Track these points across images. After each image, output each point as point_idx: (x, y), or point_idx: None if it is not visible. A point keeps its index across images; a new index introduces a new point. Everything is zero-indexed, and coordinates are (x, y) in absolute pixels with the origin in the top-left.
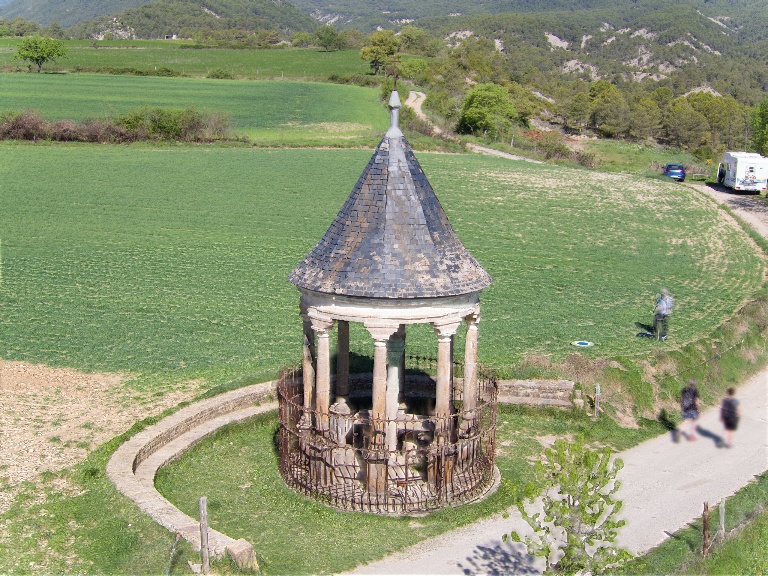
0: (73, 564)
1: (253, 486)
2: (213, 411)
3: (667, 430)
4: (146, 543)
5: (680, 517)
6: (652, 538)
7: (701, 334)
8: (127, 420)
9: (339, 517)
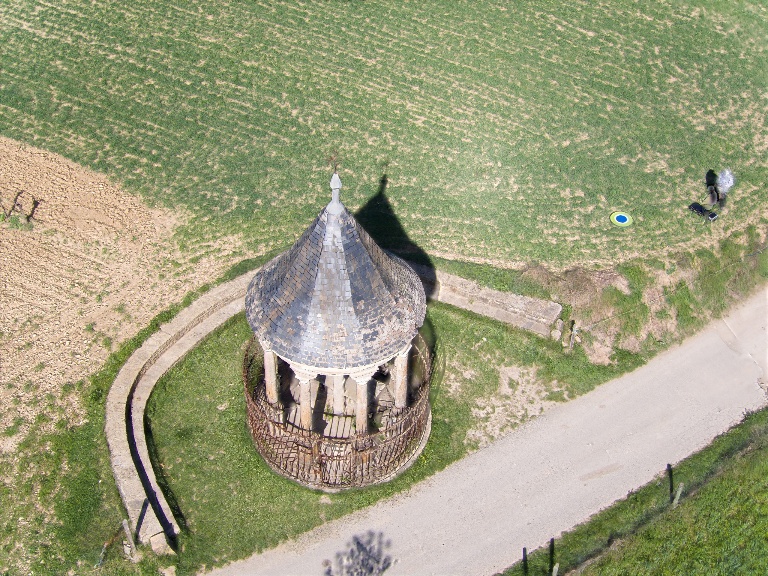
0: (48, 524)
1: (227, 410)
2: (228, 299)
3: (638, 366)
4: (105, 507)
5: (552, 527)
6: (507, 558)
7: (765, 207)
8: (154, 304)
9: (270, 478)
